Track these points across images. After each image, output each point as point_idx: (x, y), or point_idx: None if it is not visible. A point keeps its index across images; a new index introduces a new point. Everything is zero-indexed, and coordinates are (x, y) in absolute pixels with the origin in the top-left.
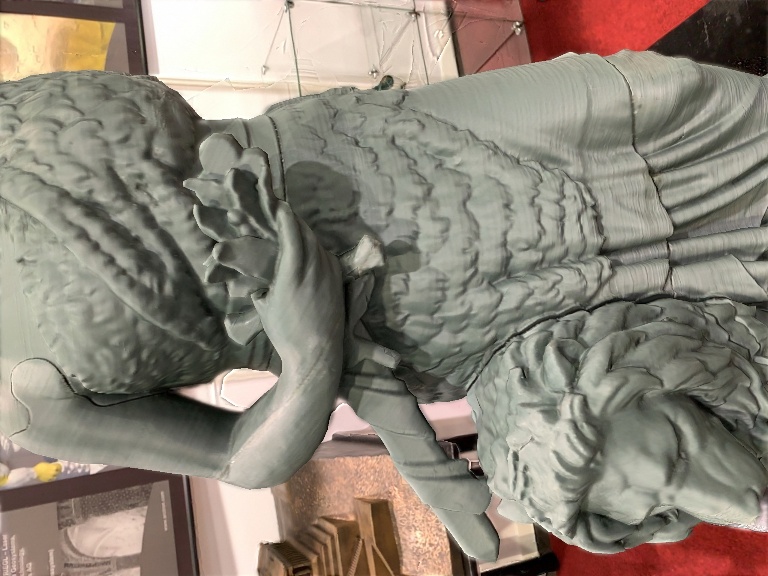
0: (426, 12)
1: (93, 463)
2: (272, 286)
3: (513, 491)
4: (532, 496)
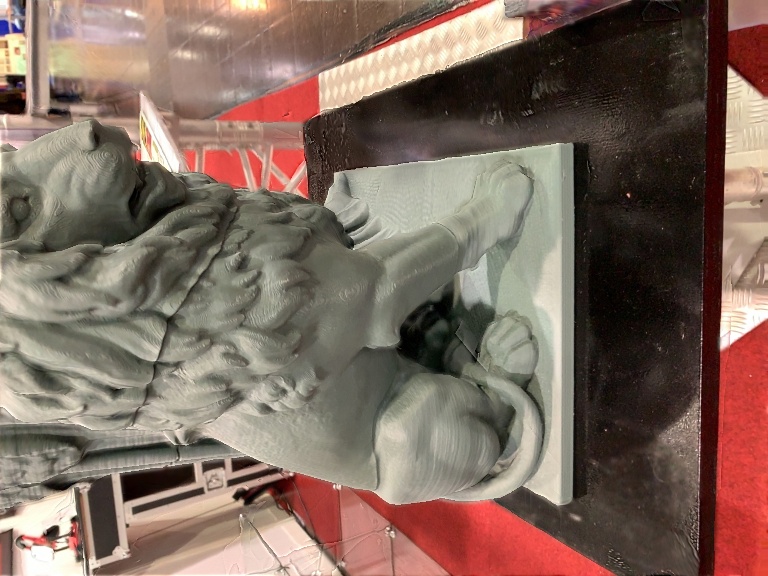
0: (294, 563)
1: None
2: None
3: None
4: None
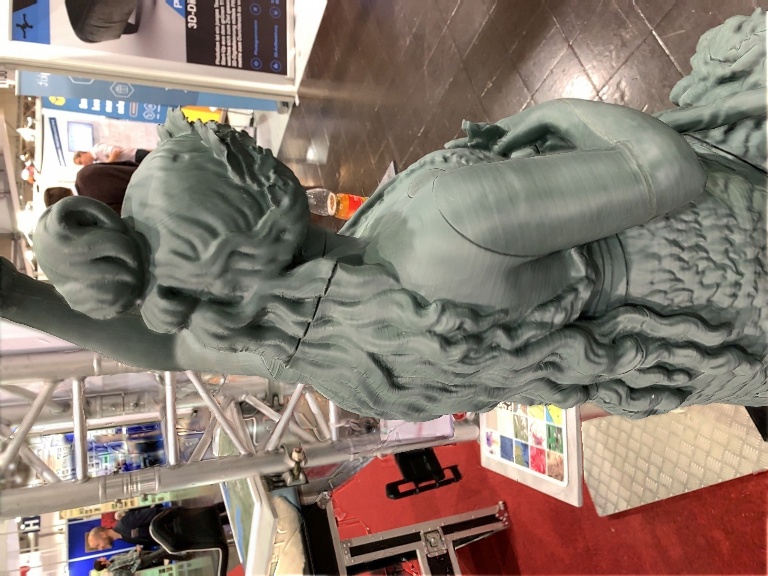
0: None
1: (515, 175)
2: (505, 127)
3: (755, 45)
4: (748, 31)
